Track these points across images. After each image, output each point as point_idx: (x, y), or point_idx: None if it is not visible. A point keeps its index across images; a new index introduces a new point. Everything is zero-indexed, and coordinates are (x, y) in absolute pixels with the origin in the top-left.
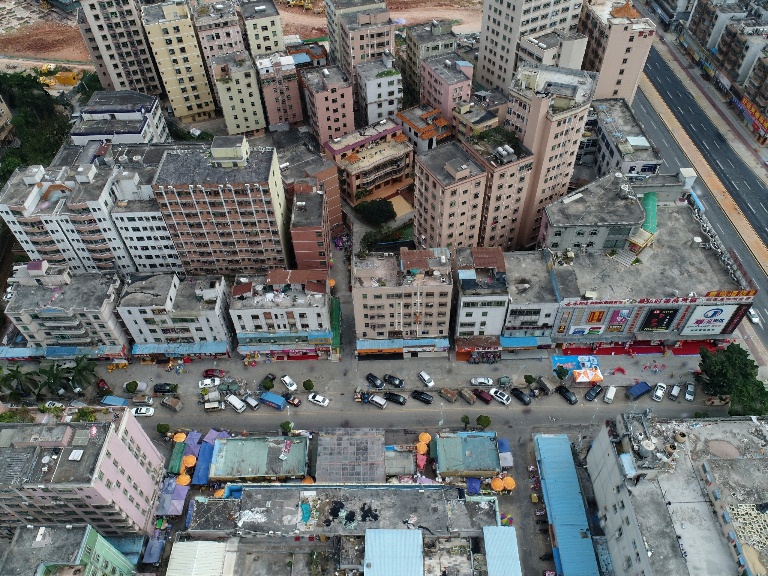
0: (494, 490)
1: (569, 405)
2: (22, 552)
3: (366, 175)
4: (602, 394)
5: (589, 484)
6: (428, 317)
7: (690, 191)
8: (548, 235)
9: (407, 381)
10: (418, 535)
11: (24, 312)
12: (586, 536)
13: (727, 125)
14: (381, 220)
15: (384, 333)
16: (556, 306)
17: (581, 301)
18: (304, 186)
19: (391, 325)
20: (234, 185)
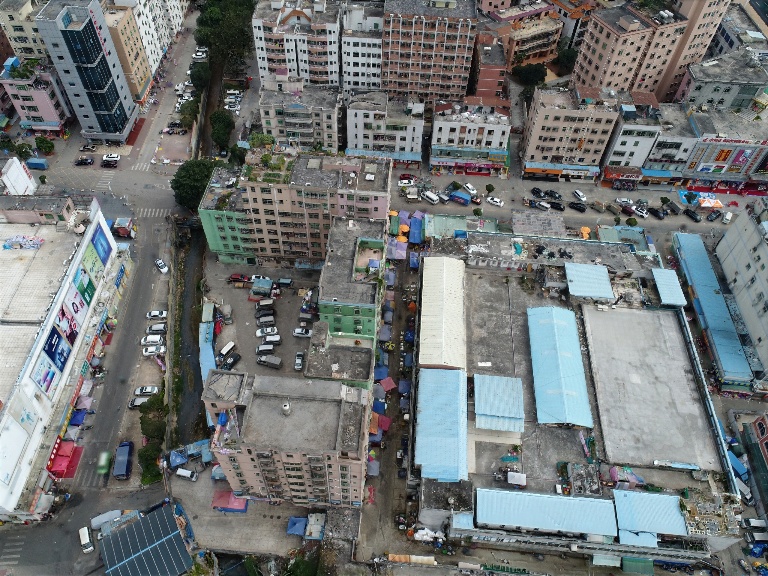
0: None
1: (694, 223)
2: (341, 232)
3: (524, 43)
4: (720, 218)
5: (718, 265)
6: (589, 143)
7: None
8: (690, 89)
9: (564, 196)
10: (604, 268)
11: (273, 107)
12: (719, 293)
13: None
14: (537, 79)
15: (548, 157)
16: (695, 141)
17: (716, 138)
18: (487, 37)
19: (557, 150)
20: (450, 19)
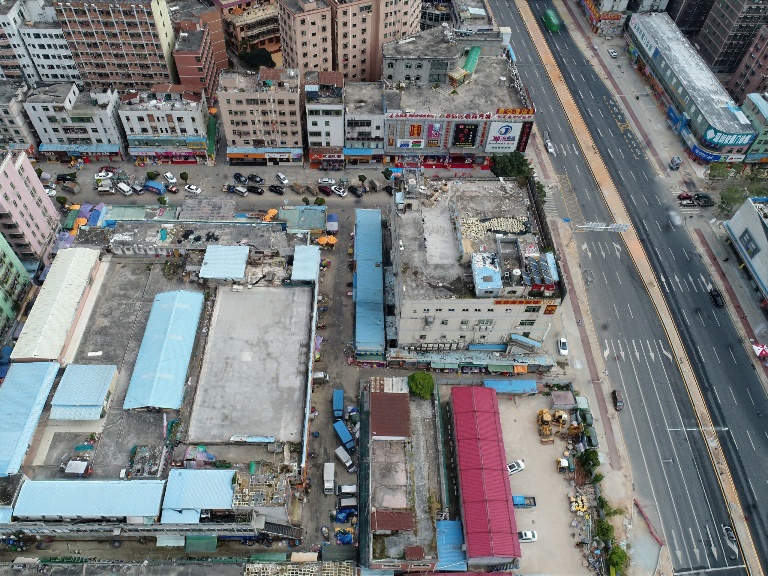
0: (320, 244)
1: None
2: None
3: (250, 28)
4: None
5: (390, 238)
6: (283, 125)
7: (508, 47)
8: (383, 67)
9: (267, 180)
10: (246, 249)
11: None
12: (379, 266)
13: (572, 19)
14: (260, 64)
15: (250, 142)
16: (383, 118)
17: None
18: (189, 23)
19: (254, 133)
20: (122, 6)
